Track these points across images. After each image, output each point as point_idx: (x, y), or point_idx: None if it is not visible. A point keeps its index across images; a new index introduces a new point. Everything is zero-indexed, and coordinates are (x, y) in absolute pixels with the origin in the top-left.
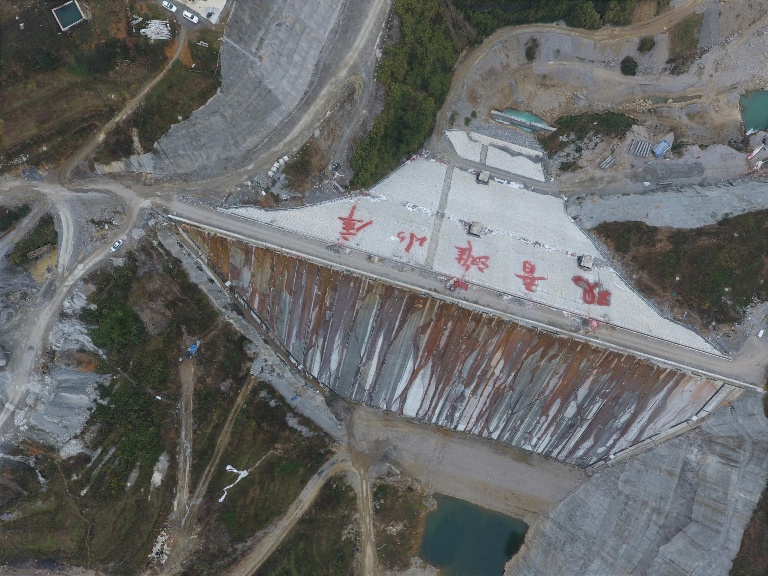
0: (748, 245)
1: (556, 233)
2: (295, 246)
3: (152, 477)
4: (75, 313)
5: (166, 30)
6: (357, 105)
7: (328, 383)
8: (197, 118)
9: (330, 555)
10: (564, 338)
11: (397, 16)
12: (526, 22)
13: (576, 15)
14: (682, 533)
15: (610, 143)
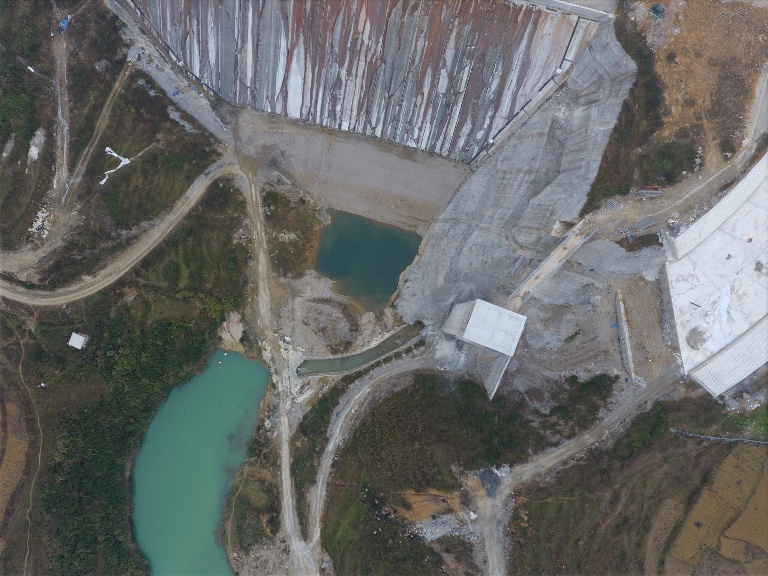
0: None
1: None
2: None
3: (29, 151)
4: None
5: None
6: None
7: (211, 84)
8: None
9: (221, 256)
10: None
11: None
12: None
13: None
14: (550, 184)
15: None
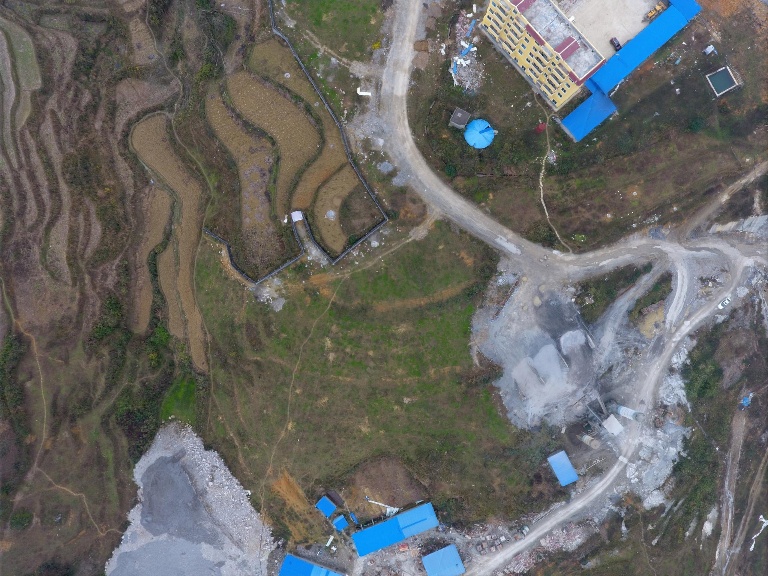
0: None
1: None
2: None
3: (703, 526)
4: (678, 368)
5: None
6: None
7: None
8: None
9: None
10: None
11: None
12: None
13: None
14: None
15: None
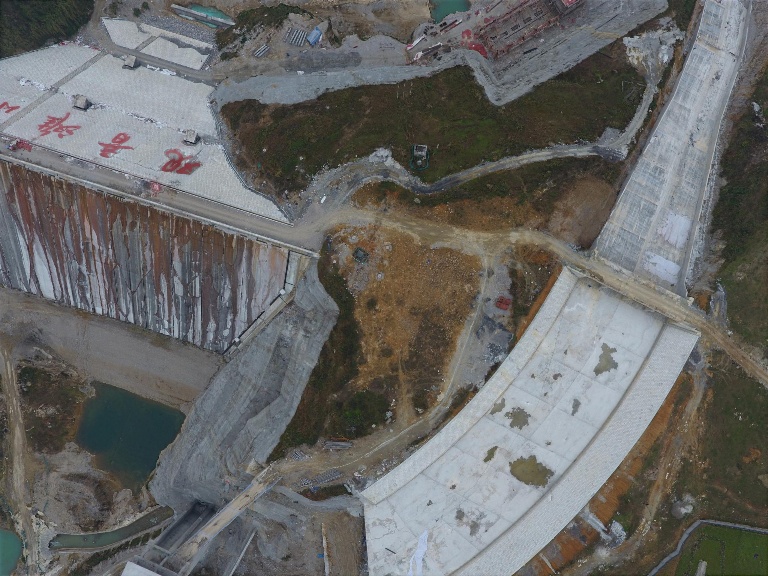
0: (336, 117)
1: (179, 113)
2: None
3: None
4: None
5: None
6: None
7: None
8: None
9: None
10: (131, 202)
11: None
12: None
13: None
14: (268, 406)
15: (267, 32)
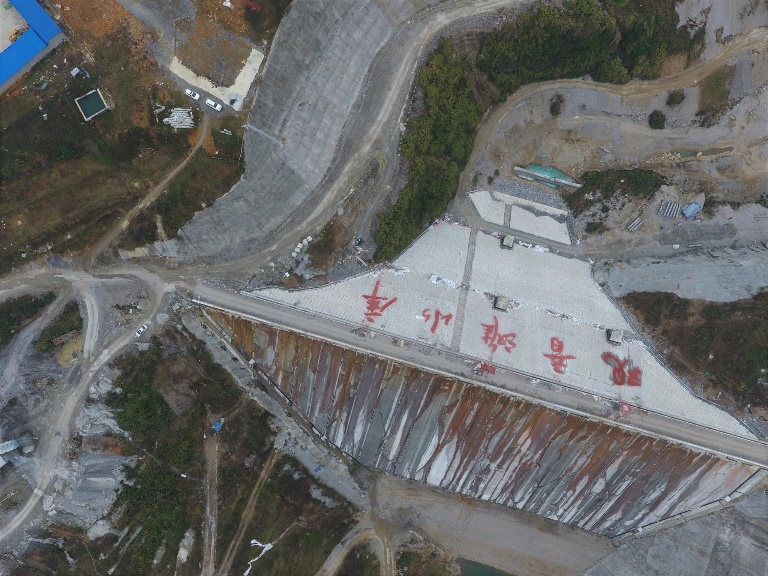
0: None
1: (583, 303)
2: (320, 330)
3: (178, 553)
4: (101, 398)
5: (189, 119)
6: (381, 180)
7: (351, 453)
8: (221, 205)
9: None
10: (594, 422)
11: (421, 88)
12: (551, 78)
13: (603, 71)
14: None
15: (638, 204)
